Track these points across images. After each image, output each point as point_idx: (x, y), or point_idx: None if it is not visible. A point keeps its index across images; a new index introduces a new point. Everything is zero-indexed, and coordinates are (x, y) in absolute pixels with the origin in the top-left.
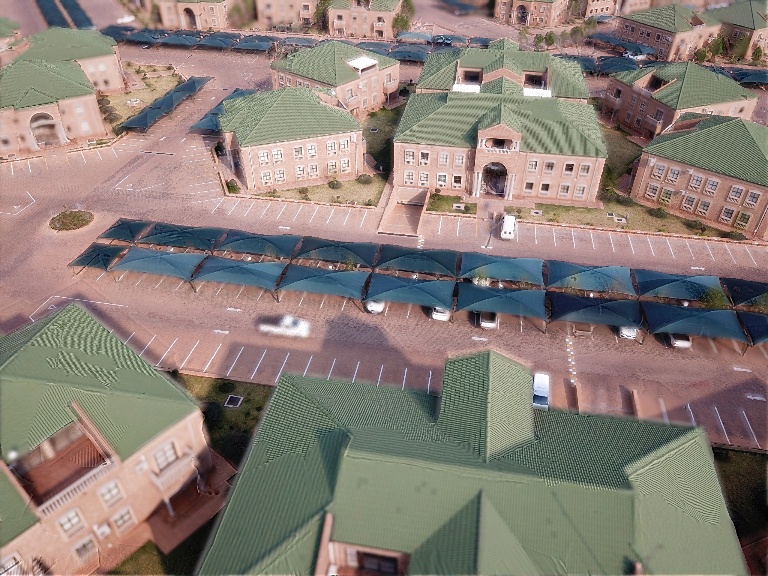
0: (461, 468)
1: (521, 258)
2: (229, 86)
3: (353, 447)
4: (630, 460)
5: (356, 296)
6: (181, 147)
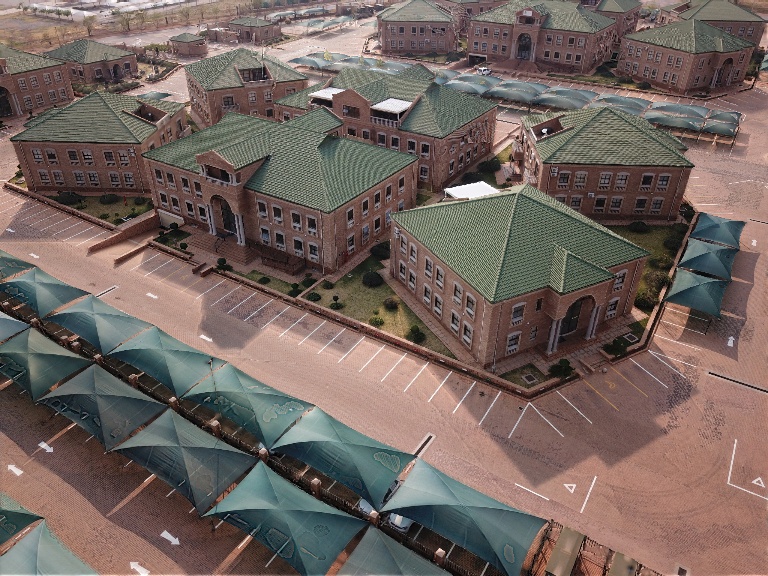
0: (550, 2)
1: (452, 83)
2: (766, 407)
3: (576, 5)
4: (503, 8)
5: (553, 87)
6: (748, 229)
